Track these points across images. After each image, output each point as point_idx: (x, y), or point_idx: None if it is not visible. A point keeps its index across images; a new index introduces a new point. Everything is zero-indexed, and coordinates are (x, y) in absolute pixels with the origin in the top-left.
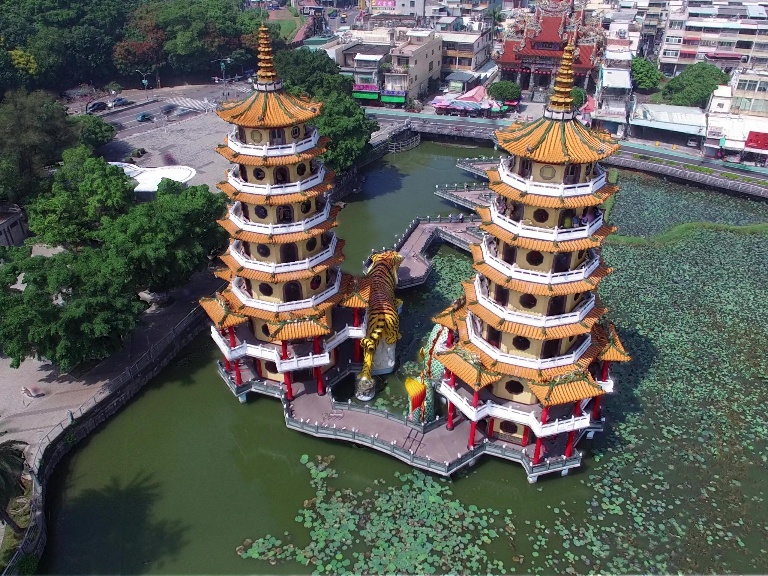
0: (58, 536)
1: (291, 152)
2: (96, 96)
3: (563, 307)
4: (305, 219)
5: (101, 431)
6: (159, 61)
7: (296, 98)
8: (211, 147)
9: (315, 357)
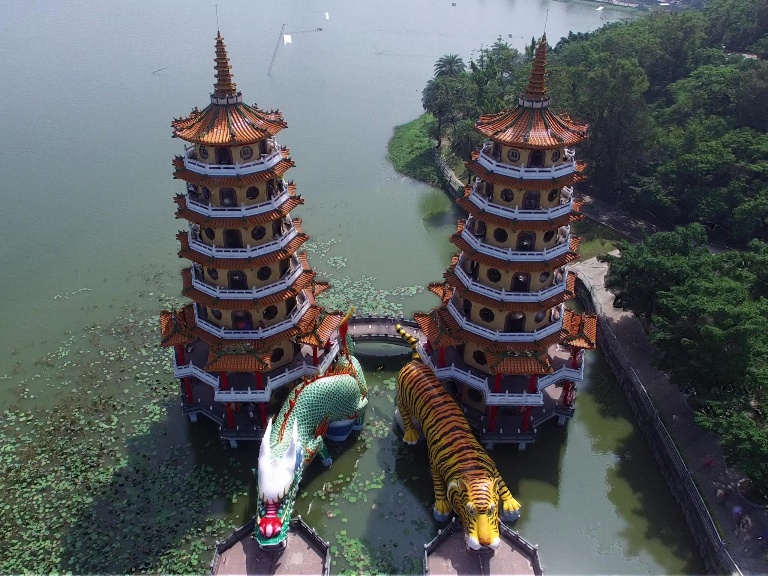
0: None
1: None
2: None
3: None
4: None
5: None
6: None
7: (512, 122)
8: None
9: None
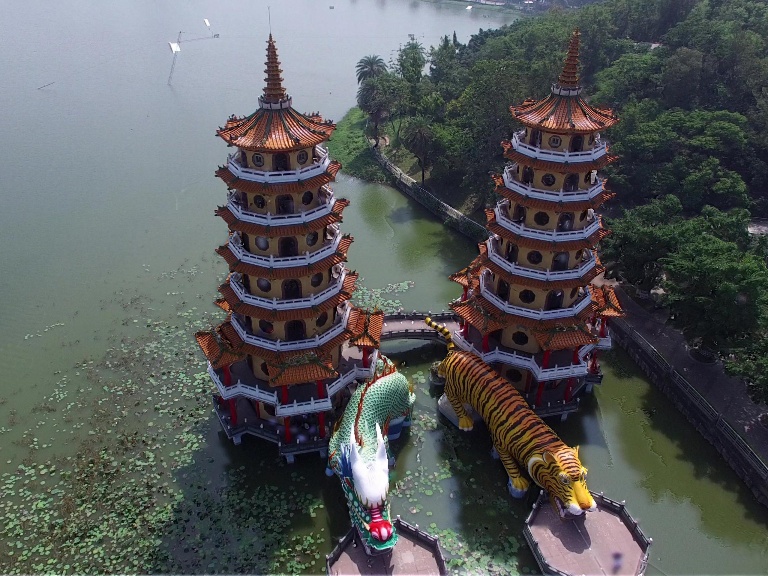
0: None
1: None
2: None
3: None
4: (502, 205)
5: None
6: None
7: (551, 110)
8: None
9: None
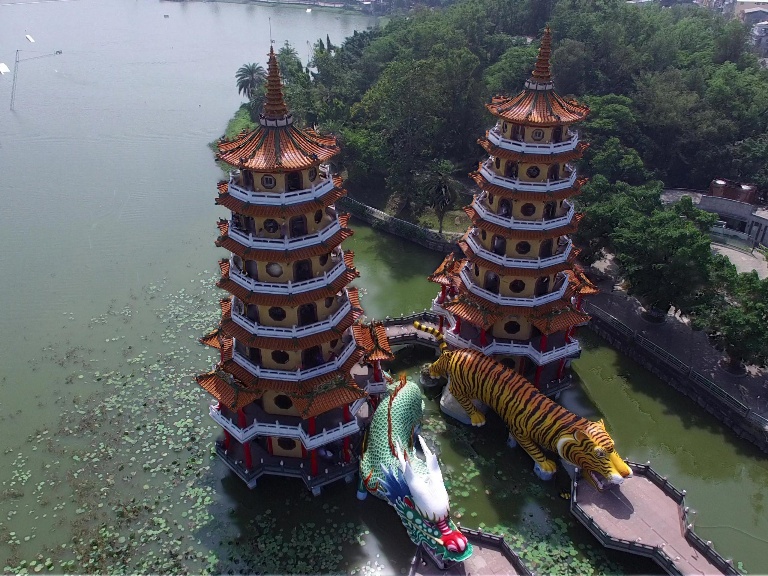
0: None
1: None
2: None
3: None
4: (481, 201)
5: None
6: None
7: (531, 105)
8: None
9: None
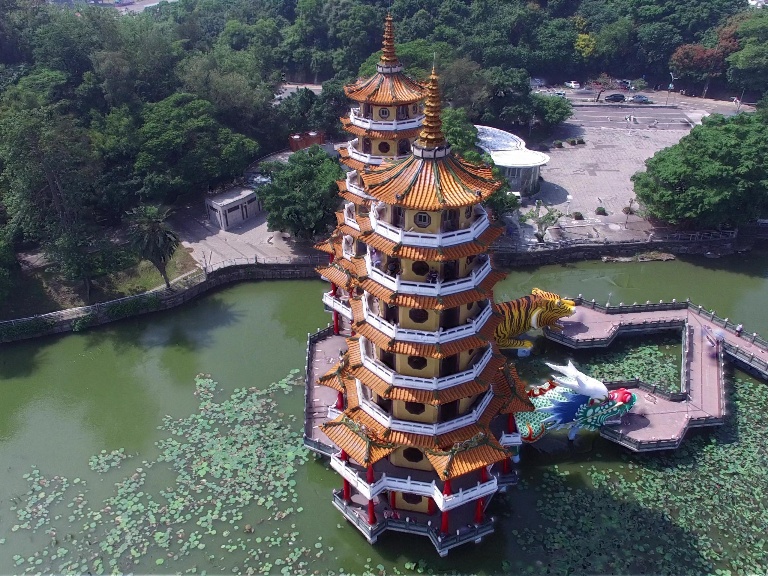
0: (191, 309)
1: (368, 127)
2: (608, 86)
3: (394, 362)
4: None
5: (270, 281)
6: (715, 71)
7: (405, 85)
8: (641, 159)
9: (344, 307)
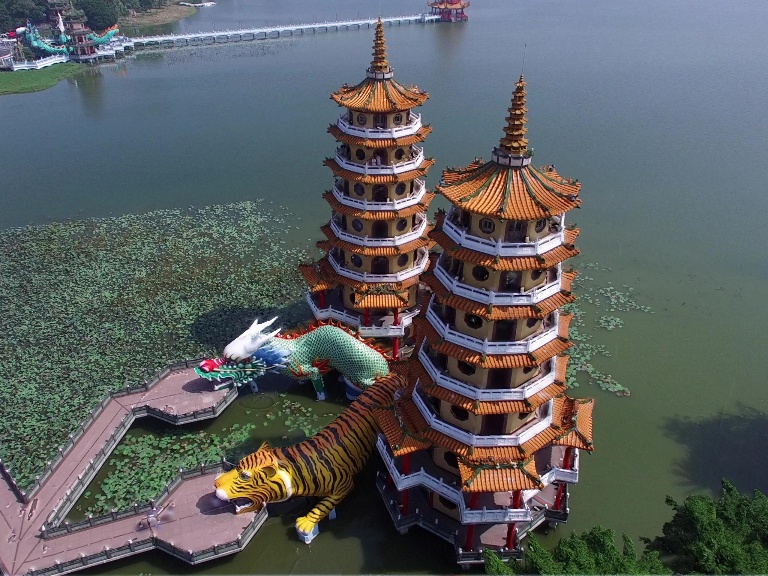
0: None
1: None
2: None
3: None
4: None
5: None
6: None
7: None
8: None
9: None
